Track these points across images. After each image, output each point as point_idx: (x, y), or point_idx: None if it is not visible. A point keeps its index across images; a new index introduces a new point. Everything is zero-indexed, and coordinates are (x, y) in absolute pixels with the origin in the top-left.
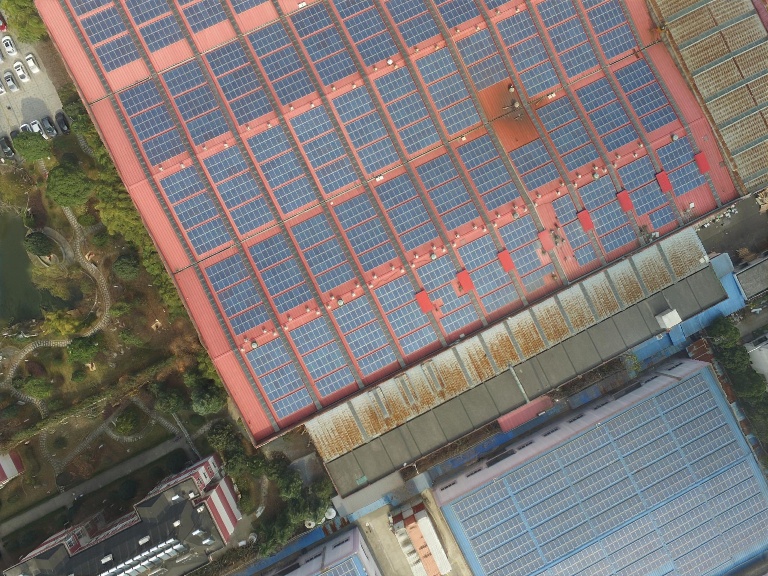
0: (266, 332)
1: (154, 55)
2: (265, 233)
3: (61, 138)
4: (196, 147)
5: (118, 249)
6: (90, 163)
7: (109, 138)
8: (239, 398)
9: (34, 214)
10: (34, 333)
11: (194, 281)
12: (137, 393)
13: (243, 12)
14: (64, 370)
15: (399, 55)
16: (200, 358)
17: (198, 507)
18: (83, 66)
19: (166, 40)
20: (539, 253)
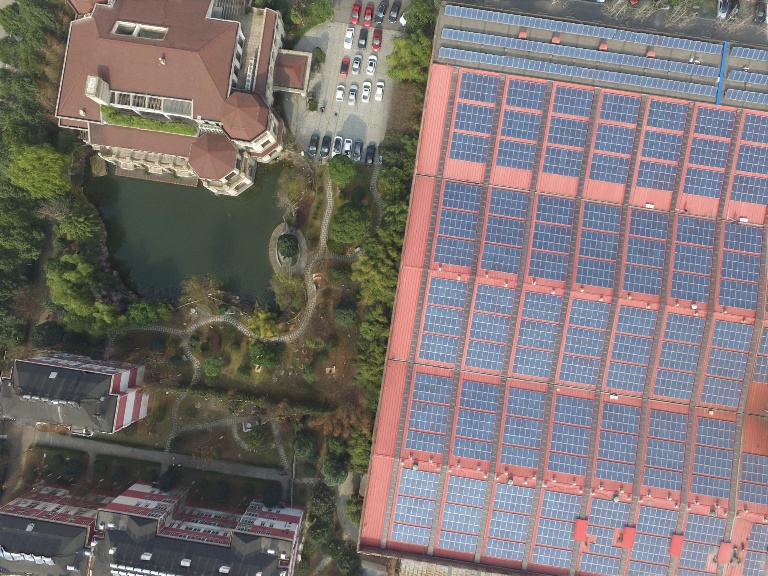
0: (432, 462)
1: (497, 168)
2: (485, 376)
3: (360, 166)
4: (480, 269)
5: (344, 287)
6: (369, 202)
7: (414, 213)
8: (371, 499)
9: (298, 215)
10: (233, 311)
11: (401, 376)
12: (283, 421)
13: (595, 180)
14: (235, 355)
15: (706, 305)
16: (356, 434)
17: (282, 570)
18: (434, 140)
19: (515, 162)
20: (710, 558)
